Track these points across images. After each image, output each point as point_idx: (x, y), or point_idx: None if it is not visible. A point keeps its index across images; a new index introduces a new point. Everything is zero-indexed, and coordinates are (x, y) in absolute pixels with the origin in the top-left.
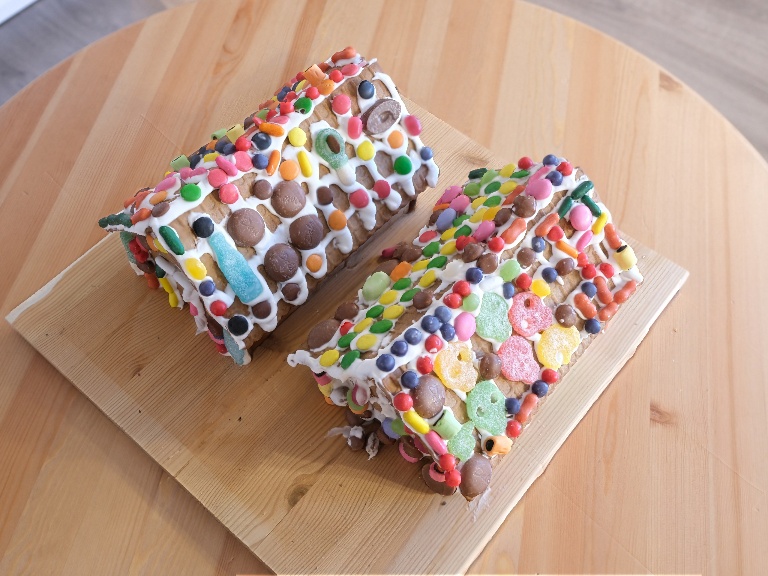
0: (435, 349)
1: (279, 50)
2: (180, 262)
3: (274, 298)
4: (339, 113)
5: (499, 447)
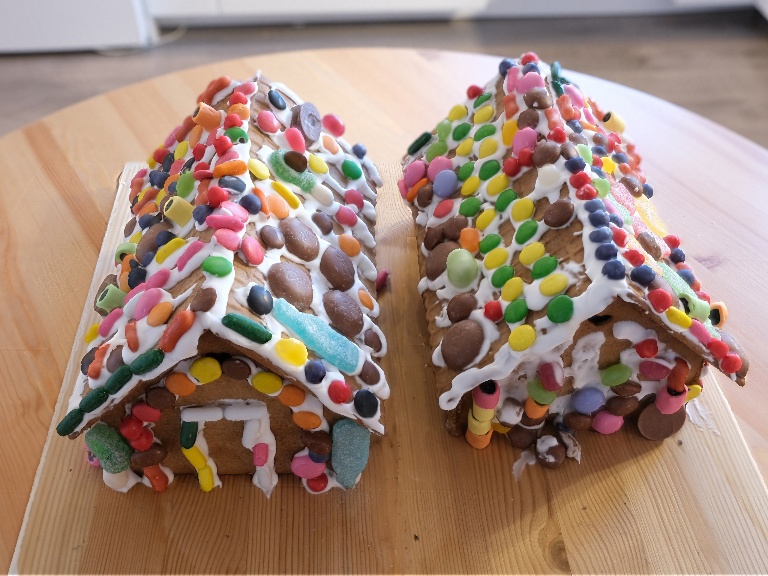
0: (628, 238)
1: (46, 201)
2: (269, 354)
3: None
4: (272, 132)
5: (725, 311)
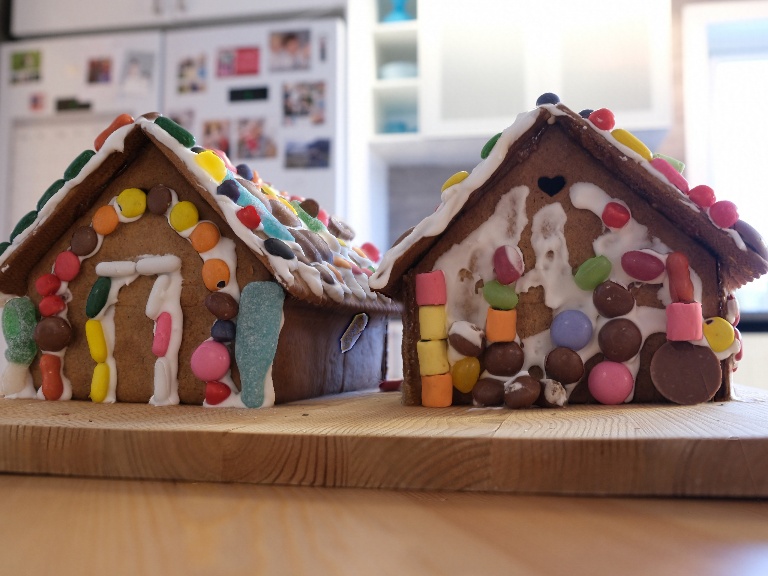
0: None
1: None
2: (187, 156)
3: None
4: None
5: None
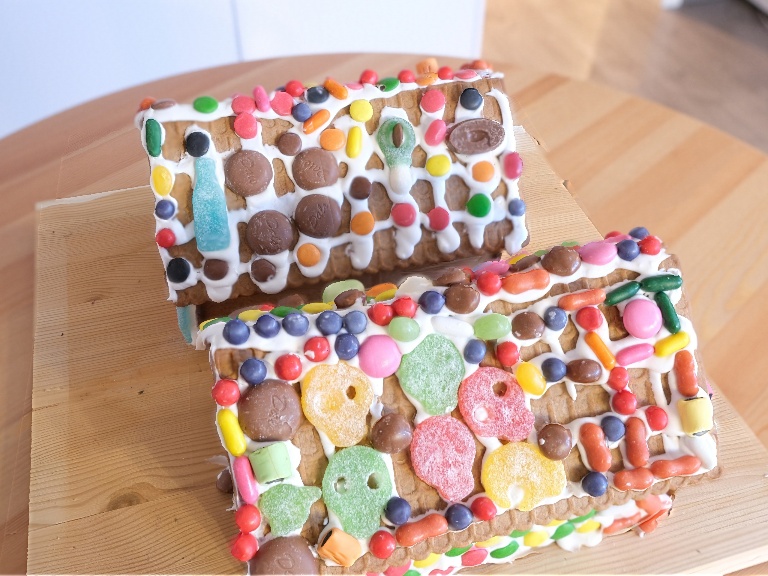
0: (312, 352)
1: None
2: (151, 166)
3: (239, 266)
4: (425, 109)
5: (334, 546)
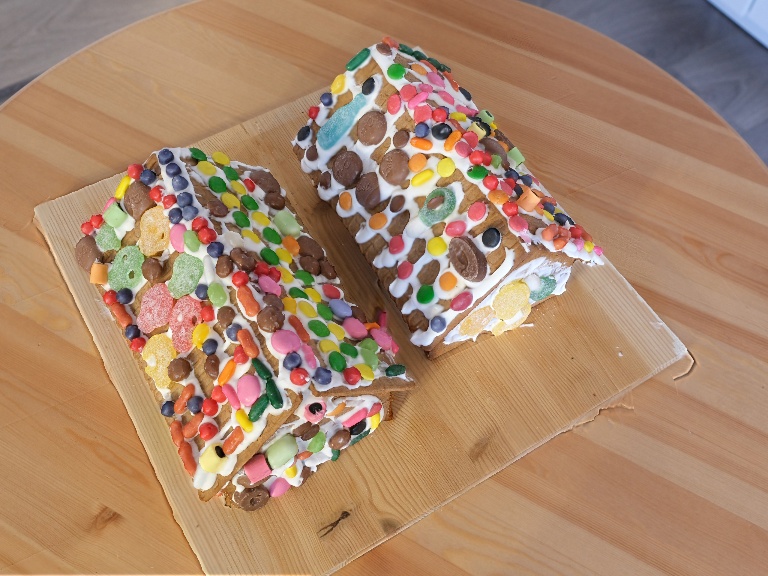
0: (163, 199)
1: (718, 306)
2: None
3: (323, 165)
4: None
5: None
